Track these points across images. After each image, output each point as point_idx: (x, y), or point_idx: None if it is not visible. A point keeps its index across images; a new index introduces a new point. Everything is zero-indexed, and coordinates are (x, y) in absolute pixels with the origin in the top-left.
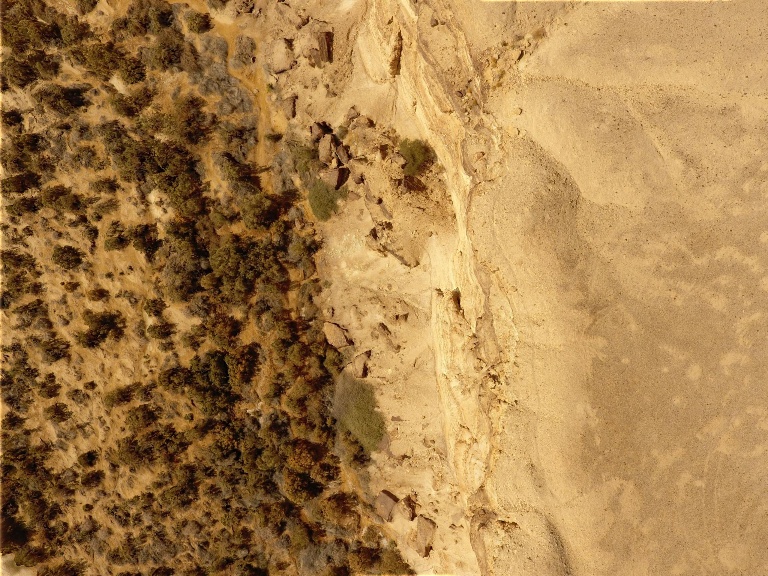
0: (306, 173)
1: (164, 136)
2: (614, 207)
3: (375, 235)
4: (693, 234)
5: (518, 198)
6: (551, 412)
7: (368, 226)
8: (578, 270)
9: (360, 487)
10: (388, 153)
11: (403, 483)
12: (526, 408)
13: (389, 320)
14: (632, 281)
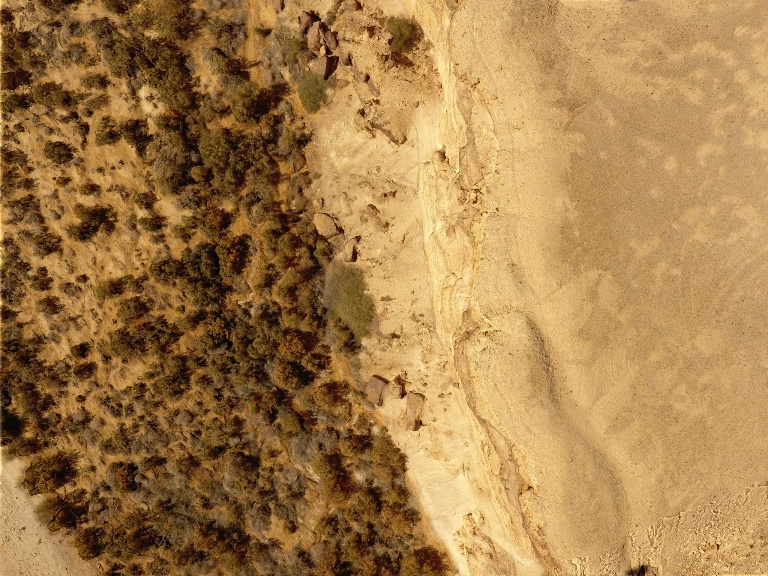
0: (295, 65)
1: (154, 33)
2: (592, 10)
3: (363, 113)
4: (669, 29)
5: (497, 6)
6: (531, 210)
7: (356, 111)
8: (557, 70)
9: (351, 375)
10: (375, 33)
11: (393, 364)
12: (507, 212)
13: (378, 199)
14: (610, 78)
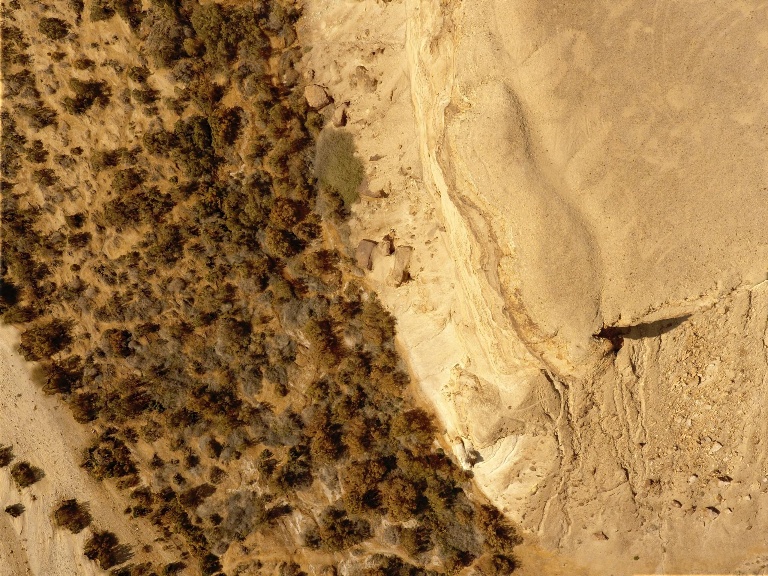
0: None
1: None
2: None
3: None
4: None
5: None
6: None
7: None
8: None
9: (341, 242)
10: None
11: (382, 225)
12: None
13: (366, 59)
14: None
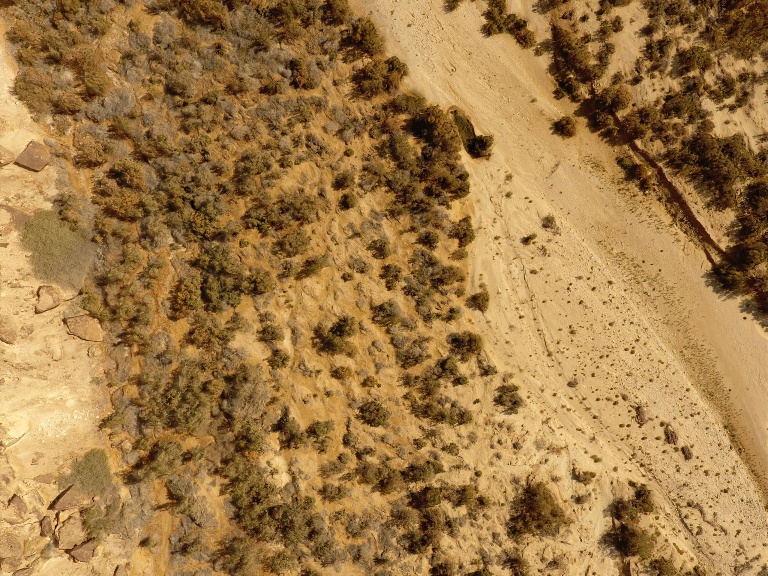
0: (111, 503)
1: (272, 547)
2: None
3: None
4: None
5: None
6: None
7: (25, 447)
8: None
9: (69, 174)
10: None
11: (6, 180)
12: None
13: None
14: None
